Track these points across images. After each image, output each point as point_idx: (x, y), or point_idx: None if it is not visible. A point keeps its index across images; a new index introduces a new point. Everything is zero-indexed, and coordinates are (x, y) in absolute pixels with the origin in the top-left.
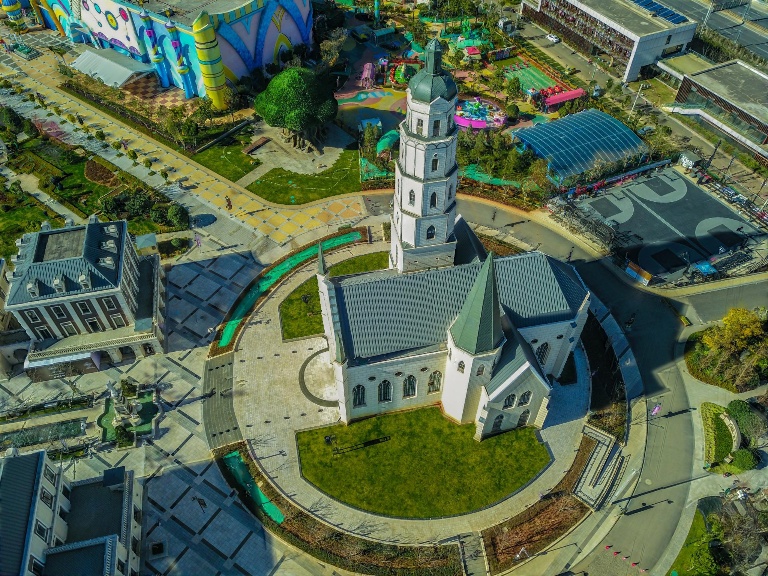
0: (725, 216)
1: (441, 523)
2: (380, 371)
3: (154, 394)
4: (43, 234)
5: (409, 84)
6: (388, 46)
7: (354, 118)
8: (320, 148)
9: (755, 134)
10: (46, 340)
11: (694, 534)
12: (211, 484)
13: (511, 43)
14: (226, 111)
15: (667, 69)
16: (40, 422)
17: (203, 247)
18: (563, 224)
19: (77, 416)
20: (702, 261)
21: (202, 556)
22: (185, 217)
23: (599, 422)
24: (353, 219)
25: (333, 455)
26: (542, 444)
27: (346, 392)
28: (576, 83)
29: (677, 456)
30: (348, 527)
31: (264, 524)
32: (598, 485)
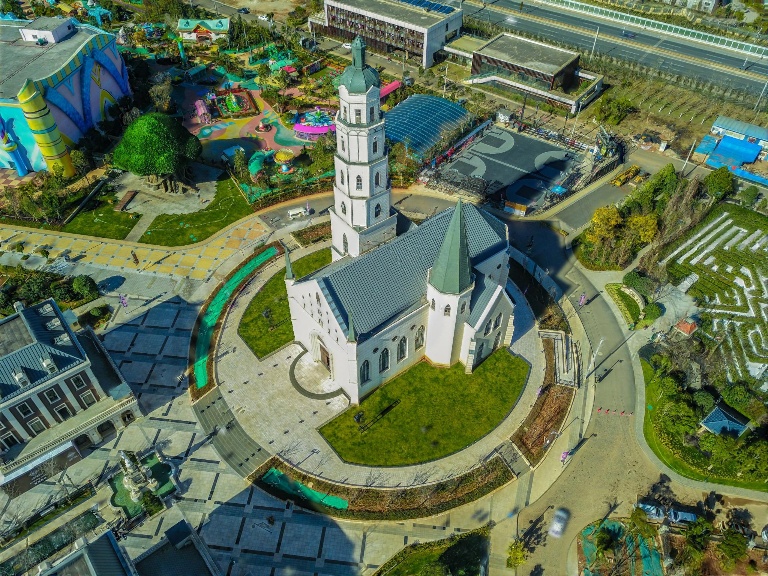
0: (549, 150)
1: (477, 446)
2: (381, 340)
3: (157, 455)
4: None
5: (341, 82)
6: (206, 82)
7: (210, 152)
8: (193, 186)
9: (542, 84)
10: (12, 448)
11: (647, 376)
12: (263, 507)
13: (316, 57)
14: (74, 177)
15: (454, 51)
16: (45, 532)
17: (126, 308)
18: (439, 190)
19: (84, 509)
20: (551, 187)
21: (291, 569)
22: (94, 285)
23: (547, 325)
24: (261, 238)
25: (361, 433)
26: (517, 357)
27: (357, 371)
28: (387, 78)
29: (609, 328)
30: (407, 483)
31: (333, 515)
32: (570, 370)
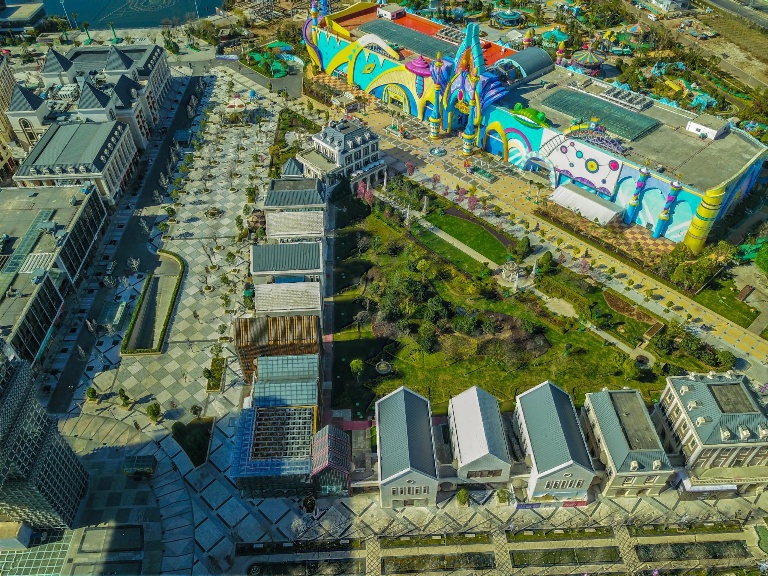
0: None
1: None
2: None
3: None
4: (708, 385)
5: None
6: None
7: None
8: None
9: None
10: (695, 468)
11: None
12: None
13: None
14: (699, 255)
15: None
16: (708, 538)
17: None
18: None
19: (736, 538)
20: None
21: None
22: None
23: None
24: None
25: None
26: None
27: None
28: None
29: None
30: None
31: None
32: None
